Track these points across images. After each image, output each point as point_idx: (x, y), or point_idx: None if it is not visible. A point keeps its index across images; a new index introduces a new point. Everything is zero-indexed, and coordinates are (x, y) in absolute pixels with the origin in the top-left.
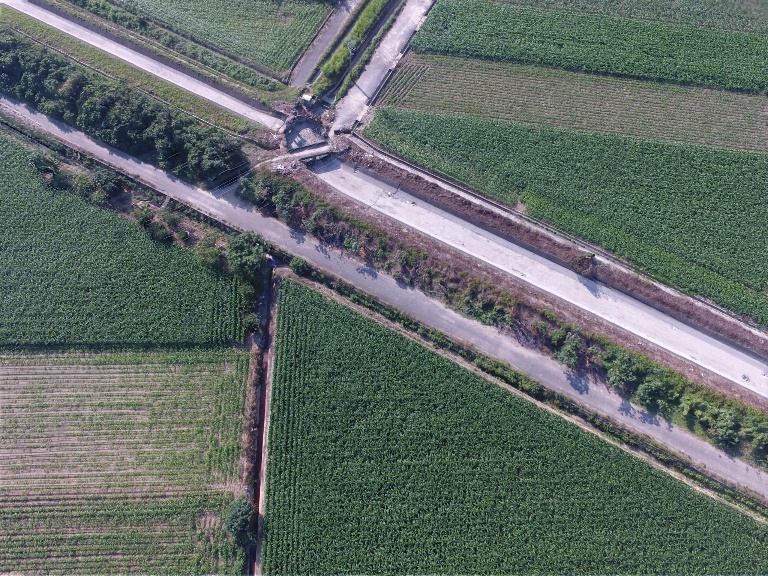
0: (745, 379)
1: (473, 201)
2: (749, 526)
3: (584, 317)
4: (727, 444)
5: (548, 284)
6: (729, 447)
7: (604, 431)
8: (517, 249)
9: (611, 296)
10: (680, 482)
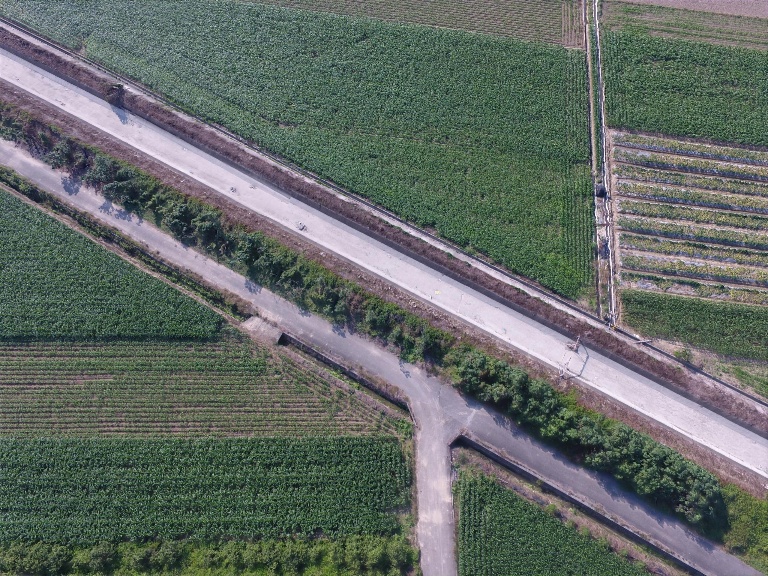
0: (232, 190)
1: (33, 43)
2: (170, 295)
3: (93, 134)
4: (182, 235)
5: (83, 112)
6: (185, 238)
7: (84, 226)
8: (65, 84)
9: (137, 123)
10: (124, 261)
